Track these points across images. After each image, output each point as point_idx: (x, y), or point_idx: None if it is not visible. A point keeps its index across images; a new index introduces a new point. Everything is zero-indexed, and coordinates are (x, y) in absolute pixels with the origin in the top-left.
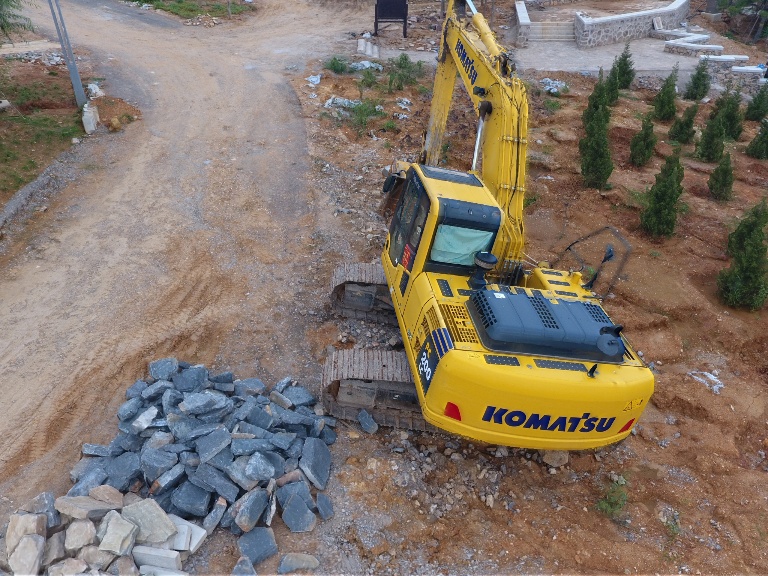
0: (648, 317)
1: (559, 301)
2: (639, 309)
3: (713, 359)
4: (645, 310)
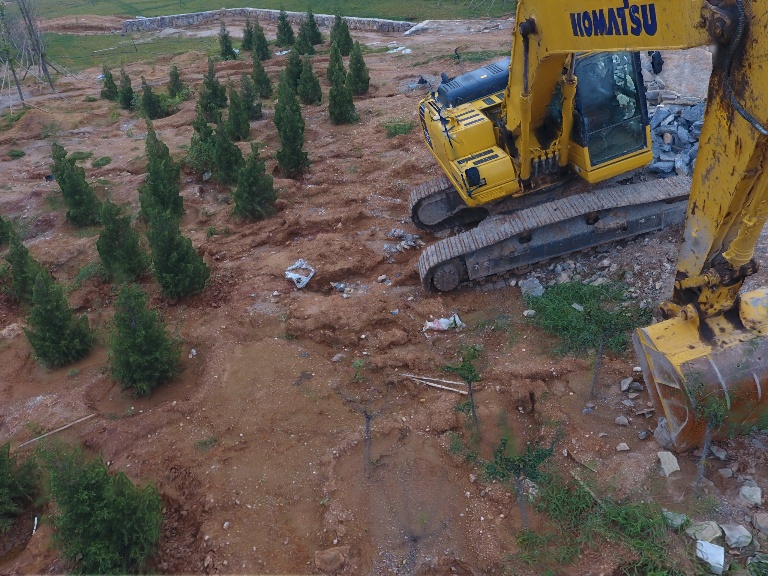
0: (313, 322)
1: (480, 78)
2: (311, 344)
3: (265, 308)
4: (305, 343)
